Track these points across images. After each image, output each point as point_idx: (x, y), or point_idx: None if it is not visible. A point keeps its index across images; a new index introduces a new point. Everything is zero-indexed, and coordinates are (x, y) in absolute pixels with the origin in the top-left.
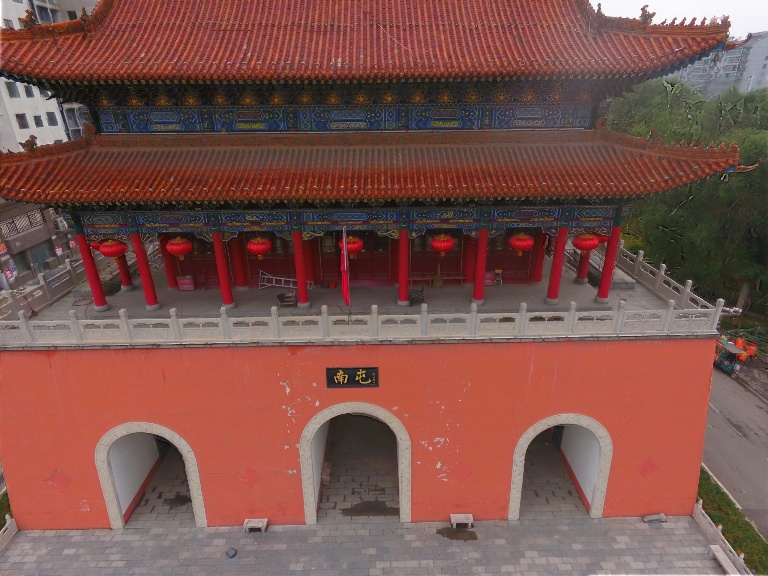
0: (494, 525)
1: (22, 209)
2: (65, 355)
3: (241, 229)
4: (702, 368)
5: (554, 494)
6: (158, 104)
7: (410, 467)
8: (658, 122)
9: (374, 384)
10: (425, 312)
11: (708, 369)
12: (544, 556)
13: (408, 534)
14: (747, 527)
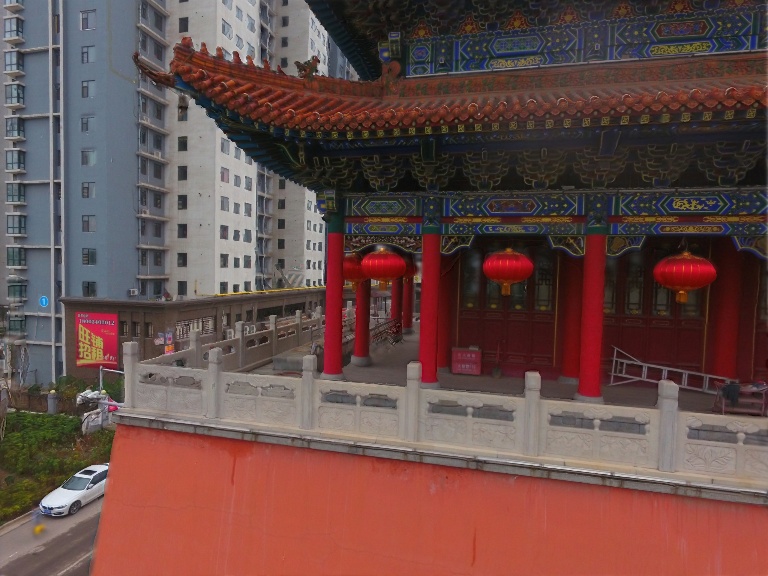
0: None
1: (200, 313)
2: (267, 457)
3: (655, 230)
4: None
5: None
6: (508, 28)
7: None
8: None
9: None
10: None
11: None
12: None
13: None
14: None
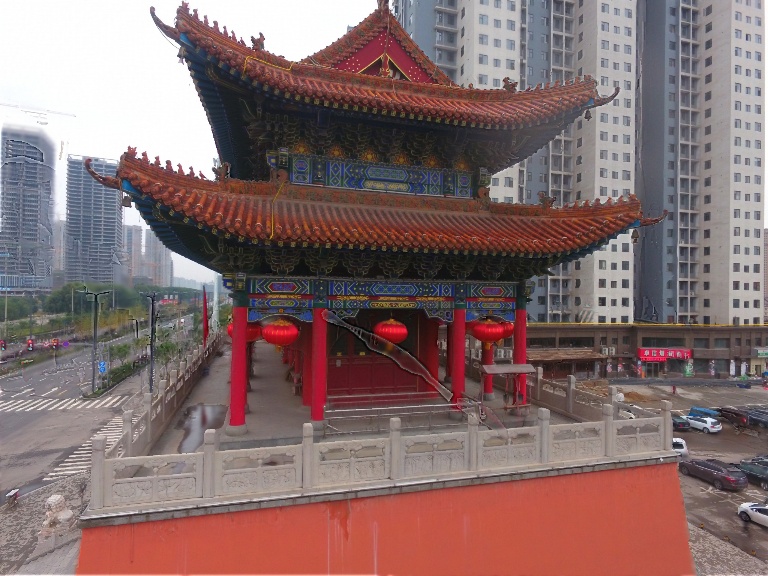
0: None
1: None
2: None
3: None
4: None
5: None
6: None
7: None
8: None
9: None
10: None
11: None
12: None
13: None
14: None
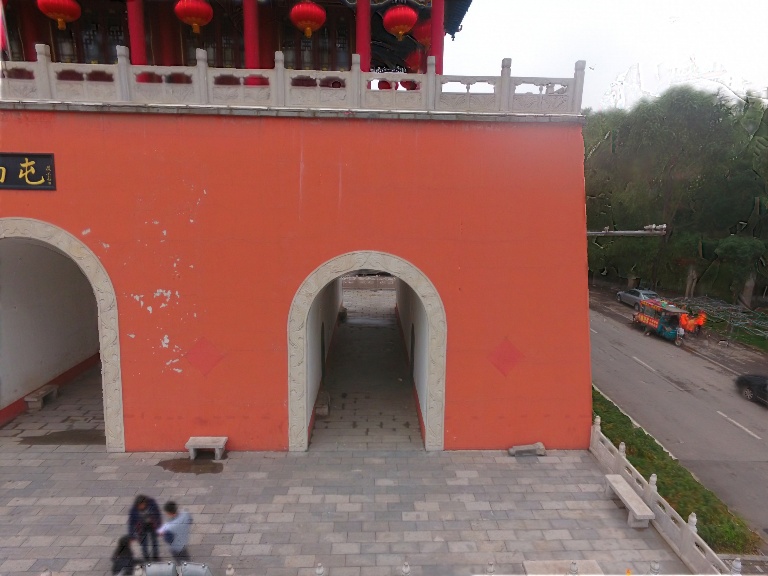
0: (261, 456)
1: None
2: None
3: None
4: (568, 177)
5: (382, 425)
6: None
7: (117, 344)
8: (591, 125)
9: (49, 186)
10: (122, 57)
11: (577, 180)
12: (320, 493)
13: (106, 465)
14: (680, 472)
